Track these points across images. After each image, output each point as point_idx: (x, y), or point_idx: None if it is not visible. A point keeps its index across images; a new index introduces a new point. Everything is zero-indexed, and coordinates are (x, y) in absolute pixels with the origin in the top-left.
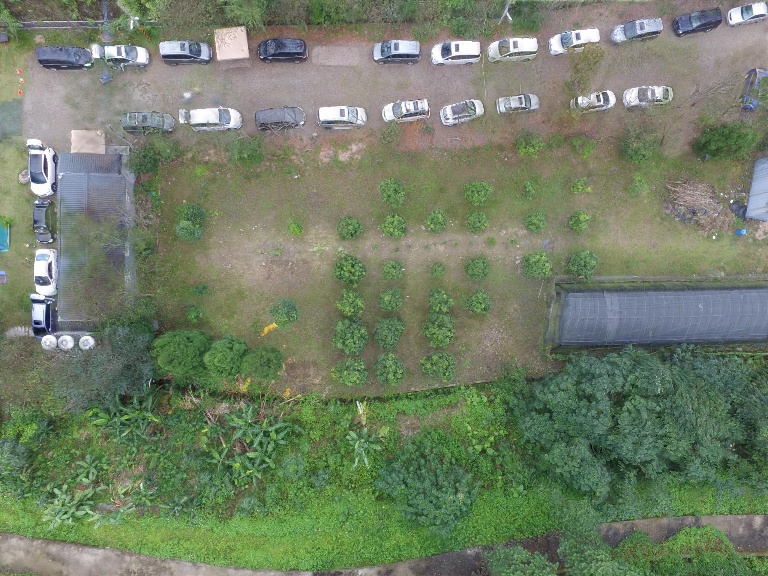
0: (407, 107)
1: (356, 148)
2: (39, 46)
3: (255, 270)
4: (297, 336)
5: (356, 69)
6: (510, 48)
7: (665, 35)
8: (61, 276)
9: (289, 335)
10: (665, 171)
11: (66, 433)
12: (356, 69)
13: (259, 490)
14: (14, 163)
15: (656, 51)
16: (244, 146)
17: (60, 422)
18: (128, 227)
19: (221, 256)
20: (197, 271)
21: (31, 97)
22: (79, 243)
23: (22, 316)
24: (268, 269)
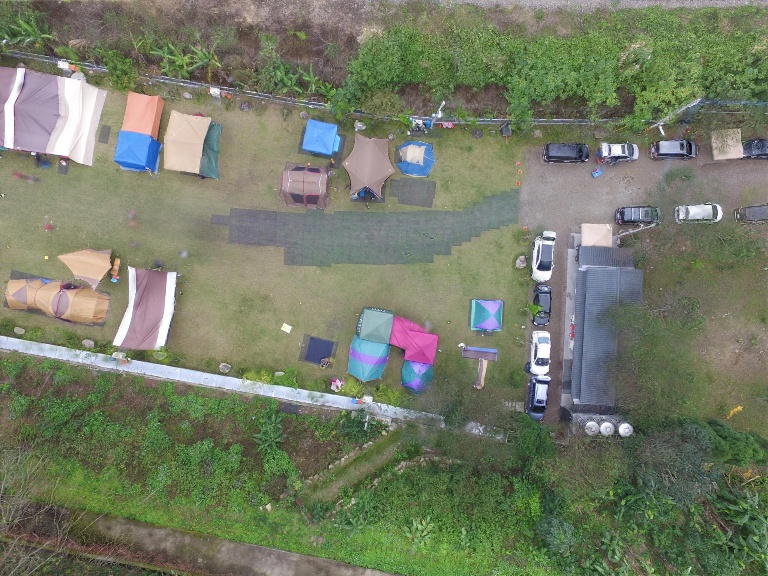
0: None
1: None
2: (535, 140)
3: (726, 356)
4: (760, 420)
5: None
6: None
7: None
8: (583, 363)
9: (753, 419)
10: None
11: (567, 507)
12: None
13: (758, 572)
14: (509, 249)
15: None
16: (752, 245)
17: (556, 495)
18: (651, 320)
19: (699, 343)
20: (670, 355)
21: (527, 187)
22: (607, 334)
23: (510, 392)
24: (737, 356)
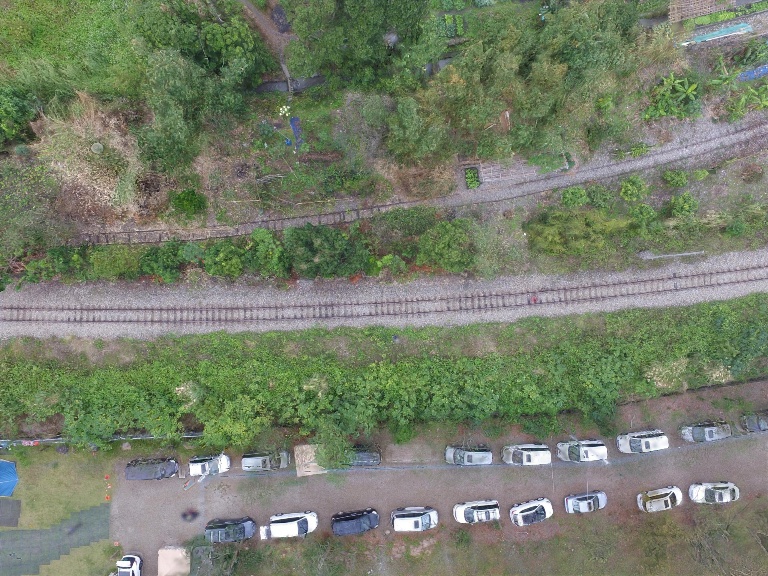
0: (479, 517)
1: (427, 544)
2: (125, 452)
3: None
4: None
5: (428, 466)
6: (580, 457)
7: (731, 427)
8: None
9: None
10: (729, 559)
11: None
12: (428, 466)
13: None
14: (101, 565)
15: (722, 443)
16: (324, 573)
17: None
18: None
19: None
20: None
21: (117, 501)
22: None
23: None
24: None
